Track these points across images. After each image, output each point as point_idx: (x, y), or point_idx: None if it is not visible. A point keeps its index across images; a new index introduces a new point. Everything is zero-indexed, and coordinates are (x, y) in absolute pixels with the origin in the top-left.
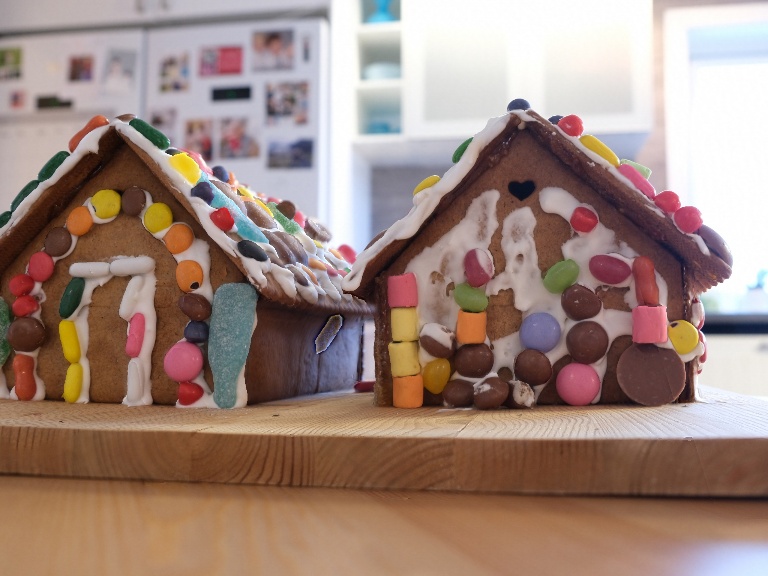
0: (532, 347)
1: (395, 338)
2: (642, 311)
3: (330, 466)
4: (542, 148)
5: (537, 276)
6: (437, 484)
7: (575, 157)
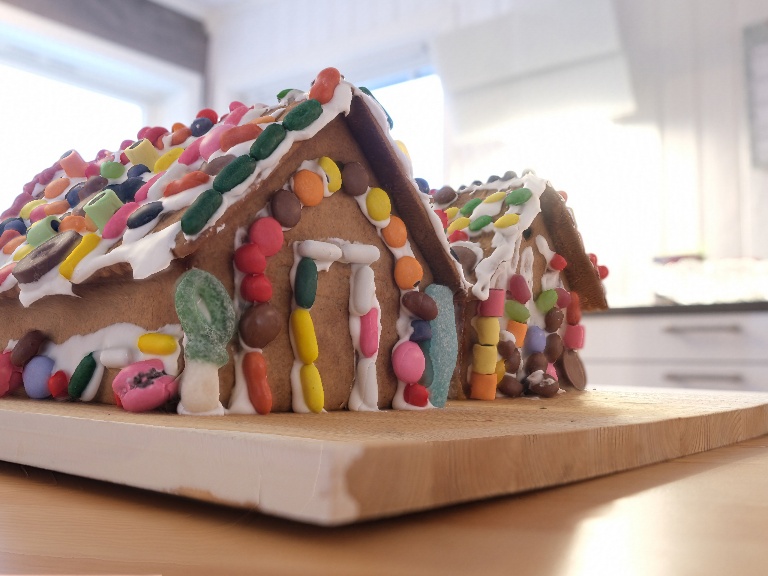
0: (539, 351)
1: (491, 342)
2: None
3: None
4: None
5: None
6: None
7: (567, 219)
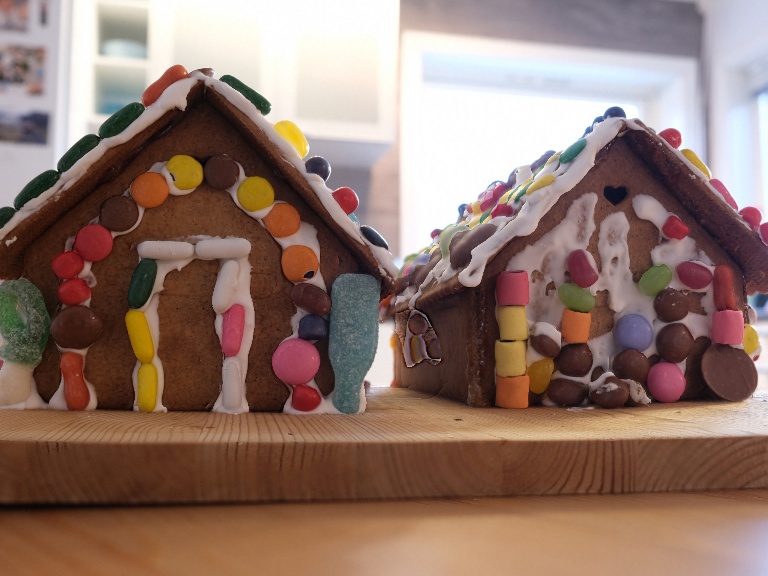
0: (632, 347)
1: (508, 337)
2: (730, 315)
3: (651, 470)
4: (636, 156)
5: (630, 279)
6: (752, 482)
7: (678, 168)
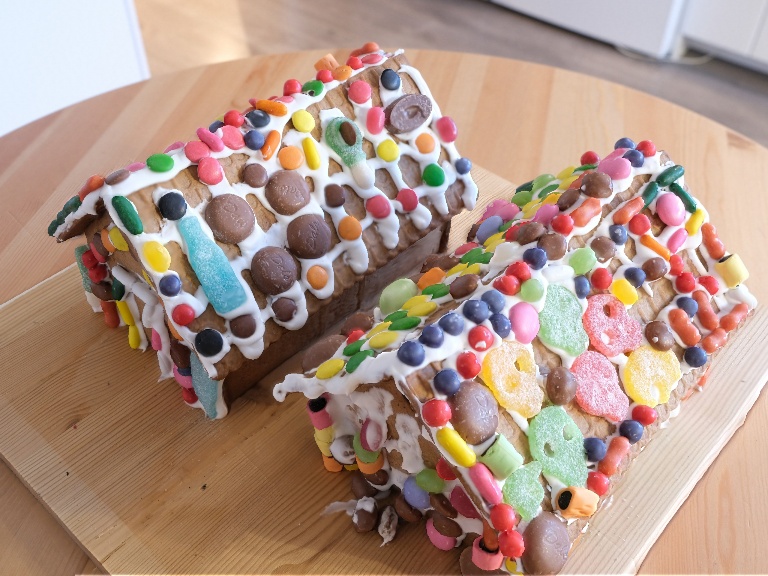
0: (406, 501)
1: None
2: (474, 552)
3: None
4: None
5: (420, 461)
6: None
7: None
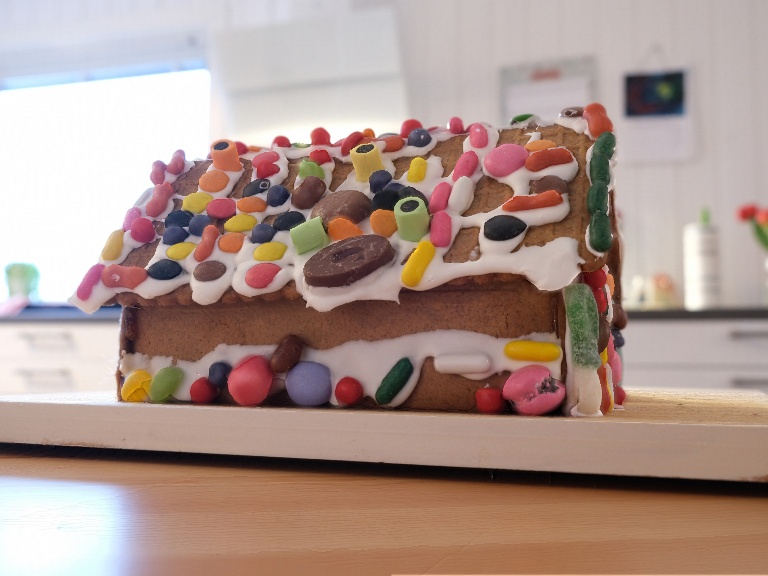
0: None
1: None
2: None
3: None
4: None
5: None
6: None
7: None
